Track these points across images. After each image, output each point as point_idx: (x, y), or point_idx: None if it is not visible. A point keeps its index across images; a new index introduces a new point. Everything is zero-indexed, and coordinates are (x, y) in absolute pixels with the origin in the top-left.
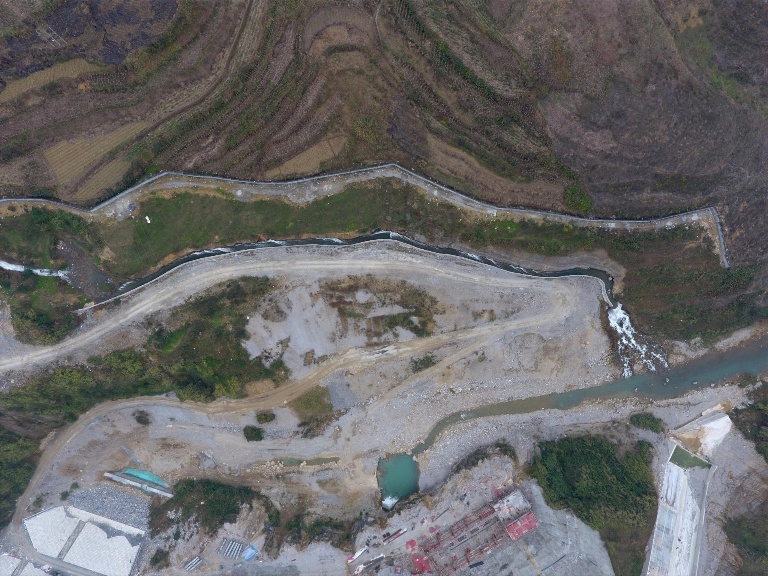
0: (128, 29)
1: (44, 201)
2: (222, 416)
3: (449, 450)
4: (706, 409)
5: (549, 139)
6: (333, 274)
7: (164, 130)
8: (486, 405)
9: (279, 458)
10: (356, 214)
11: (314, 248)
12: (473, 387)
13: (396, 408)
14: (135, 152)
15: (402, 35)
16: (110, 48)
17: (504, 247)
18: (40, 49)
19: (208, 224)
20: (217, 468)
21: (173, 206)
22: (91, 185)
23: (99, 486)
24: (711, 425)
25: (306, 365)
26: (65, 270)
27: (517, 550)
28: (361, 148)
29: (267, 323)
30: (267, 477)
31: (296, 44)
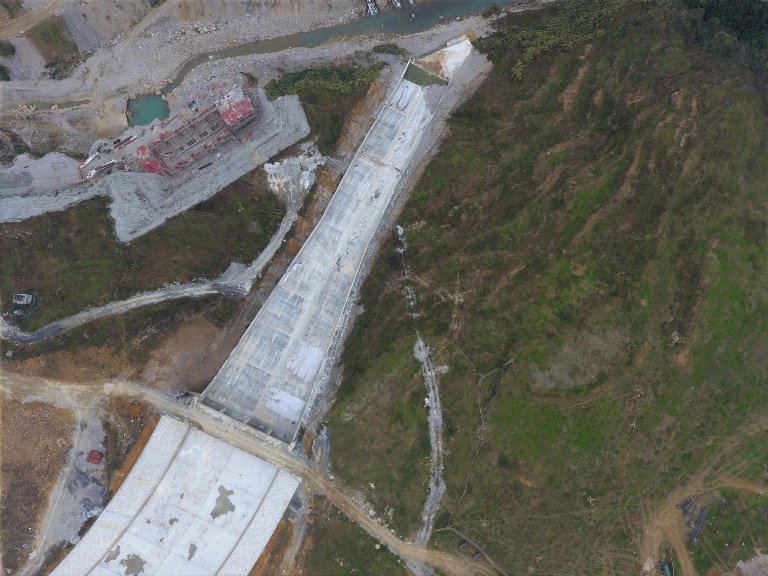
0: None
1: None
2: None
3: (196, 86)
4: (451, 40)
5: None
6: None
7: None
8: (233, 46)
9: (31, 102)
10: None
11: None
12: (218, 27)
13: (142, 49)
14: None
15: None
16: None
17: None
18: None
19: None
20: None
21: None
22: None
23: None
24: (451, 49)
25: None
26: None
27: (243, 147)
28: None
29: None
30: (18, 118)
31: None
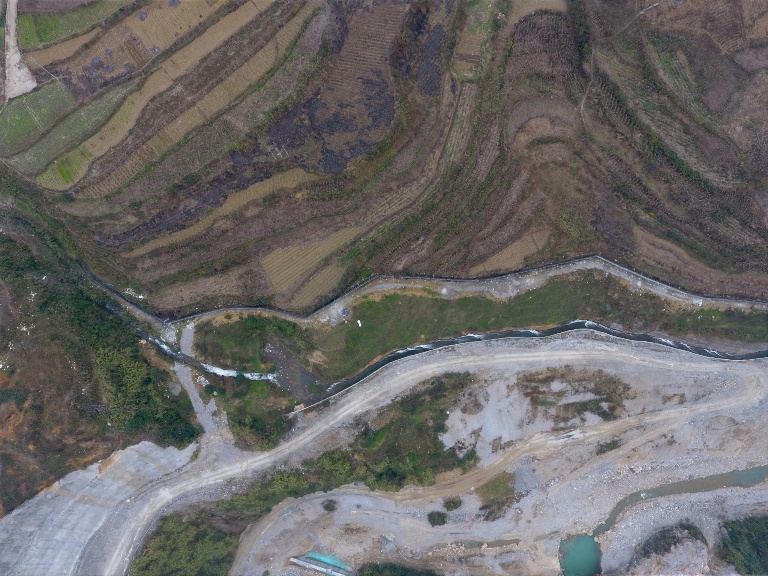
0: (346, 137)
1: (259, 308)
2: (410, 503)
3: (632, 531)
4: None
5: (767, 231)
6: (532, 366)
7: (376, 234)
8: (666, 484)
9: (460, 540)
10: (557, 307)
11: (513, 341)
12: (653, 466)
13: (577, 489)
14: (350, 258)
15: (610, 127)
16: (330, 158)
17: (706, 335)
18: (262, 162)
19: (415, 324)
20: (399, 551)
21: (382, 308)
22: (307, 292)
23: (285, 571)
24: None
25: (494, 452)
26: (274, 373)
27: None
28: (564, 241)
29: (464, 416)
30: (450, 560)
31: (501, 140)
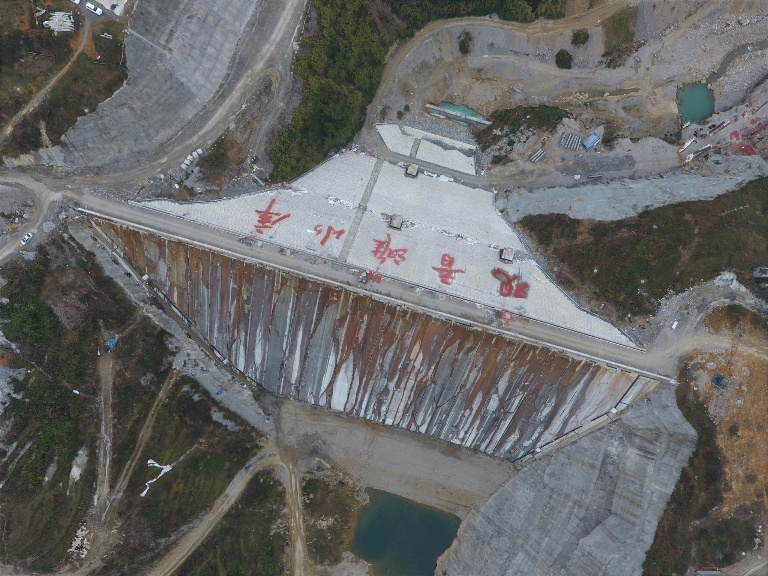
0: None
1: None
2: (541, 36)
3: (742, 76)
4: None
5: None
6: None
7: None
8: None
9: (583, 90)
10: None
11: None
12: (759, 19)
13: (690, 39)
14: None
15: None
16: None
17: None
18: None
19: None
20: (527, 100)
21: None
22: None
23: (422, 116)
24: None
25: None
26: None
27: None
28: None
29: None
30: (576, 105)
31: None
